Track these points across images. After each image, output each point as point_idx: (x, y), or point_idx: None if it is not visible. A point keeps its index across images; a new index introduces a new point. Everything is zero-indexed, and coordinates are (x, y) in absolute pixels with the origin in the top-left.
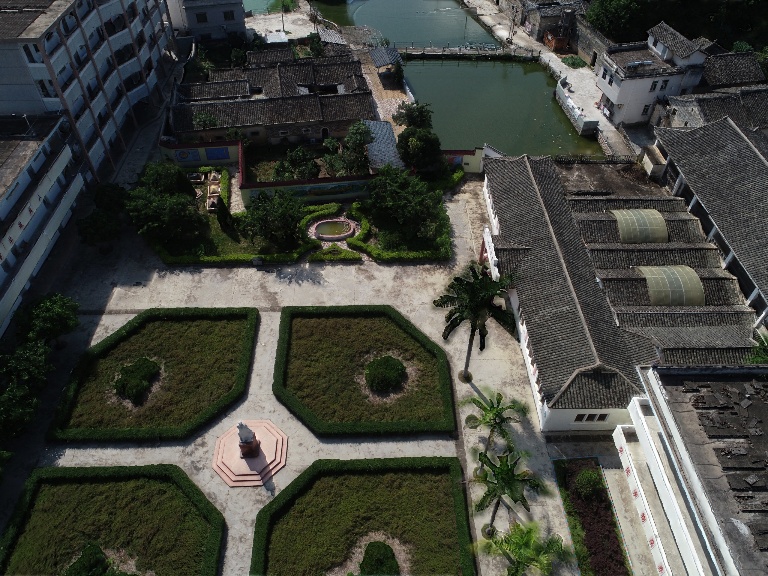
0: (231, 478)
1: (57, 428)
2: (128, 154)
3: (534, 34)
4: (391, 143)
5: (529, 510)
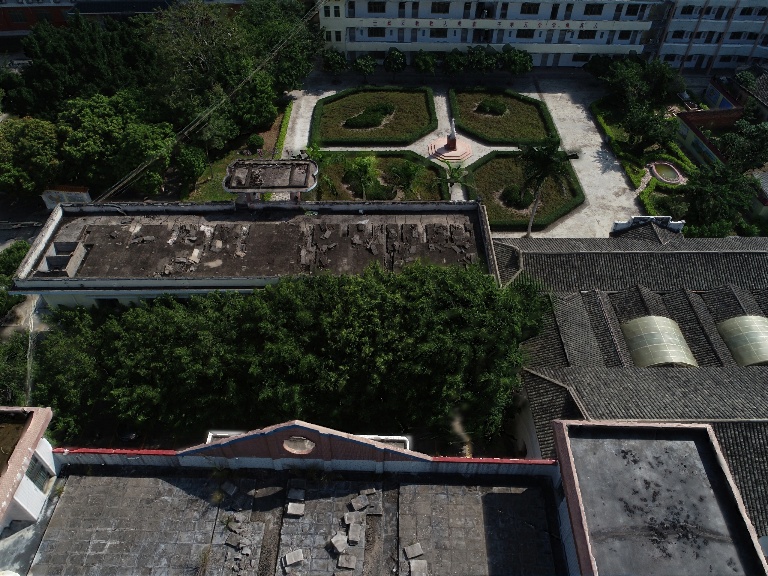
0: (433, 144)
1: (454, 89)
2: (704, 77)
3: None
4: None
5: (393, 191)
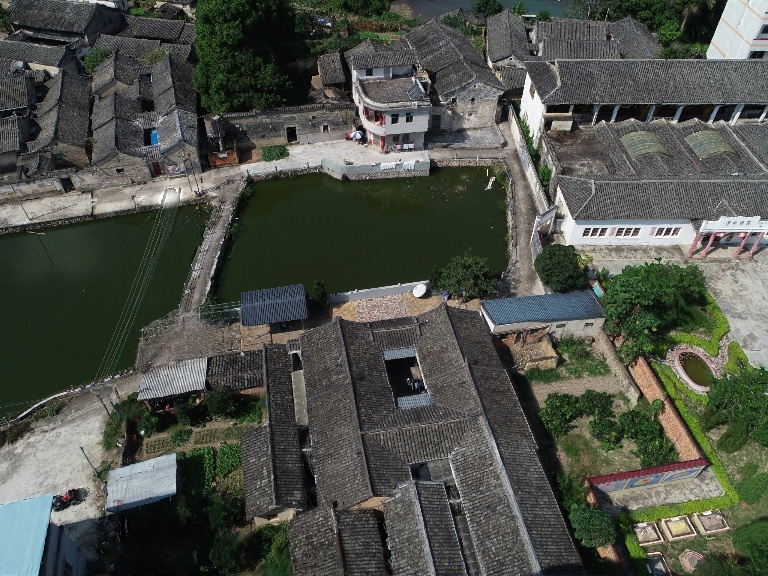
0: None
1: None
2: None
3: (194, 169)
4: (536, 300)
5: None
